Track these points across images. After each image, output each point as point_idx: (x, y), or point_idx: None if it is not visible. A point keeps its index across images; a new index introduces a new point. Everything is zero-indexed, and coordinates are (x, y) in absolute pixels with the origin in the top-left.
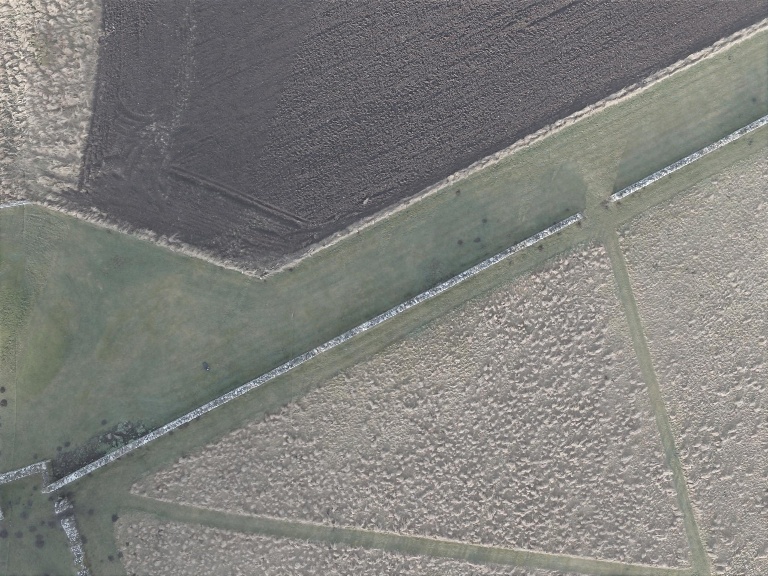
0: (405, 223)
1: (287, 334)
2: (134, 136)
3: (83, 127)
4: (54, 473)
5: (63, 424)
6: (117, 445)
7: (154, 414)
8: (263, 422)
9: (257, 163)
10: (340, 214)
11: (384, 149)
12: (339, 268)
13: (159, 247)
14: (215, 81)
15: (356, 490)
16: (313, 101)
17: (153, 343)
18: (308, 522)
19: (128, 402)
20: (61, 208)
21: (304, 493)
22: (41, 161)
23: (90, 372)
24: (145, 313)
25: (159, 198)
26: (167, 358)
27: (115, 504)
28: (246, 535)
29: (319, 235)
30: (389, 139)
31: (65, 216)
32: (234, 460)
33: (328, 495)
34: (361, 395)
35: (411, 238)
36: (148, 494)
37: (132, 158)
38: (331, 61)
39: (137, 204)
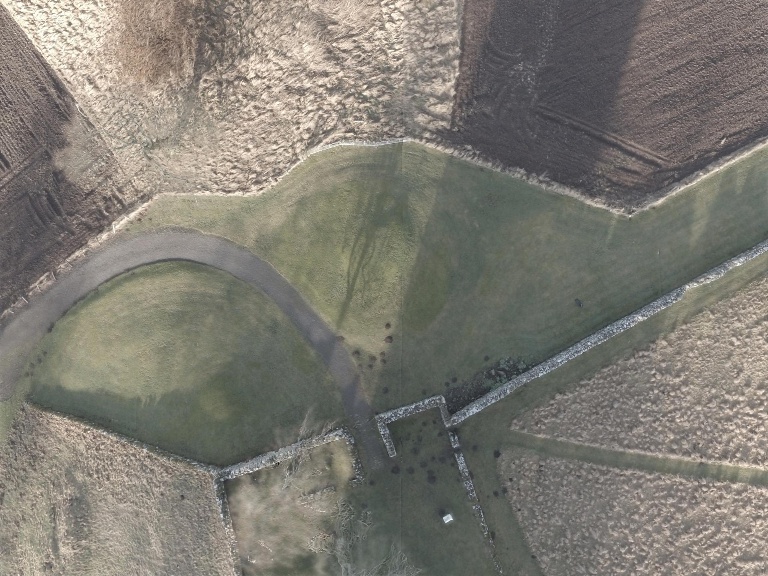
0: (760, 163)
1: (654, 271)
2: (502, 75)
3: (455, 66)
4: (447, 408)
5: (449, 360)
6: (501, 381)
7: (532, 350)
8: (633, 358)
9: (619, 103)
10: (699, 154)
11: (739, 90)
12: (700, 207)
13: (530, 185)
14: (576, 22)
15: (721, 425)
16: (670, 42)
17: (527, 280)
18: (677, 457)
19: (507, 338)
20: (438, 145)
21: (672, 429)
22: (418, 99)
23: (472, 308)
24: (519, 250)
25: (528, 137)
26: (541, 295)
27: (496, 440)
28: (620, 470)
29: (680, 174)
30: (743, 80)
31: (441, 154)
32: (606, 396)
33: (694, 430)
34: (724, 331)
35: (766, 177)
36: (527, 430)
37: (501, 97)
38: (686, 3)
39: (507, 143)
